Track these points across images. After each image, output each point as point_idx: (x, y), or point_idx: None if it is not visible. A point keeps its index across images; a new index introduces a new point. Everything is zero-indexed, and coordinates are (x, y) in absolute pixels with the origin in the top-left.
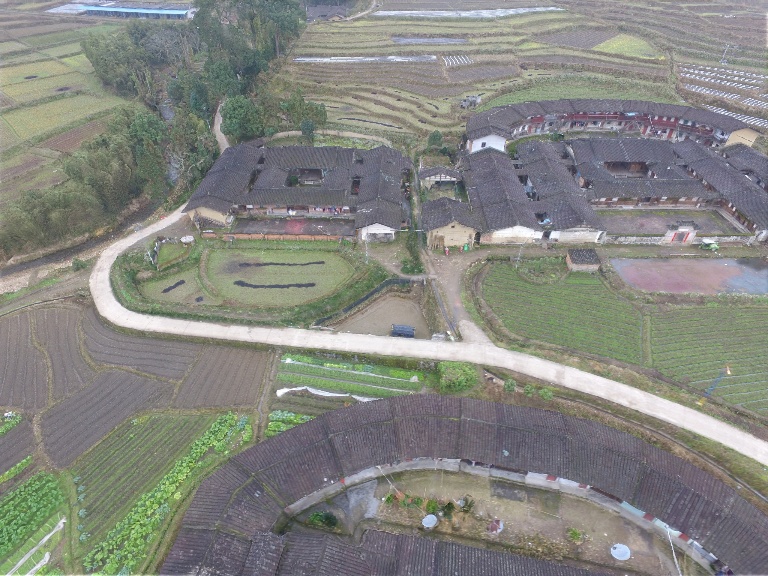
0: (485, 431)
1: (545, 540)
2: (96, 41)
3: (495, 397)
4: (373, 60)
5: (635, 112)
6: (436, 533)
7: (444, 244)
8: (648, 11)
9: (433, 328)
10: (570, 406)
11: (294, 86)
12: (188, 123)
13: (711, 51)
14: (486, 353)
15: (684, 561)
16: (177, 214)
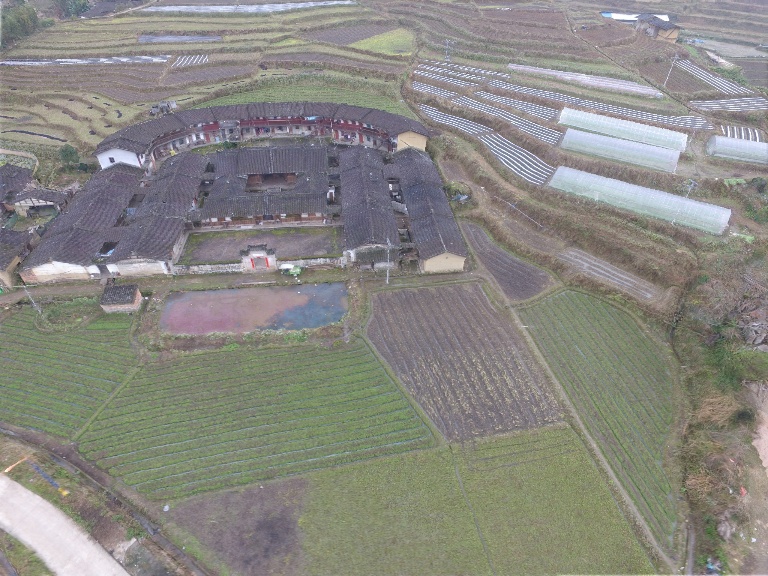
0: None
1: None
2: None
3: None
4: (92, 62)
5: (315, 116)
6: None
7: None
8: (436, 4)
9: None
10: None
11: None
12: None
13: (460, 46)
14: None
15: None
16: None
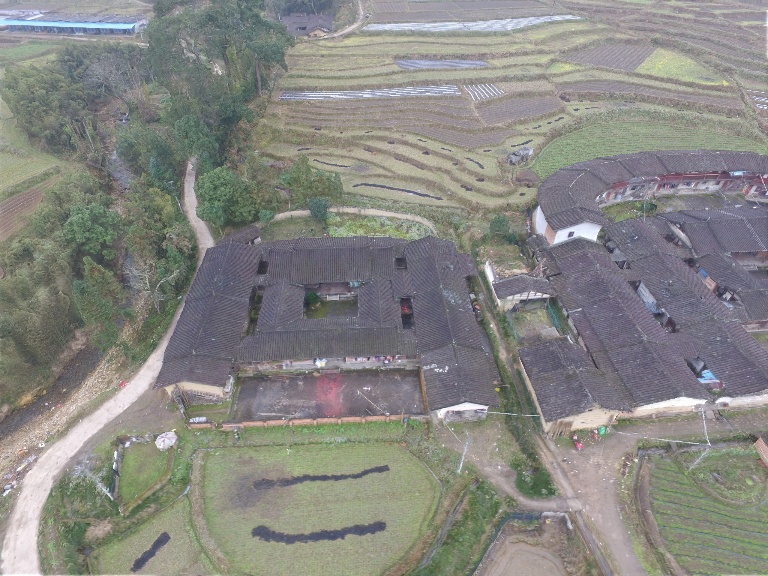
0: None
1: None
2: (14, 80)
3: None
4: (381, 94)
5: (742, 170)
6: None
7: (570, 428)
8: (678, 19)
9: None
10: None
11: (286, 135)
12: (150, 206)
13: None
14: None
15: None
16: (145, 375)
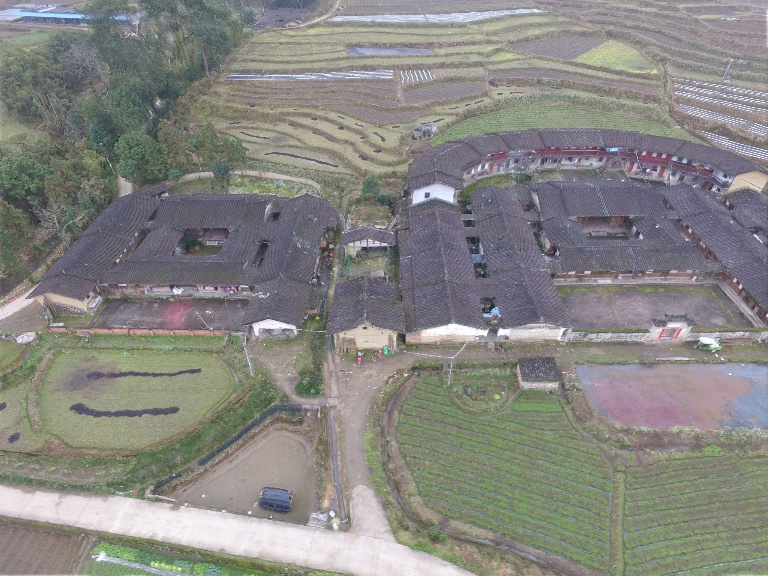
0: None
1: None
2: None
3: None
4: (319, 77)
5: (618, 147)
6: None
7: (357, 347)
8: (640, 13)
9: (319, 493)
10: None
11: (223, 110)
12: (78, 164)
13: (711, 63)
14: (379, 556)
15: None
16: None
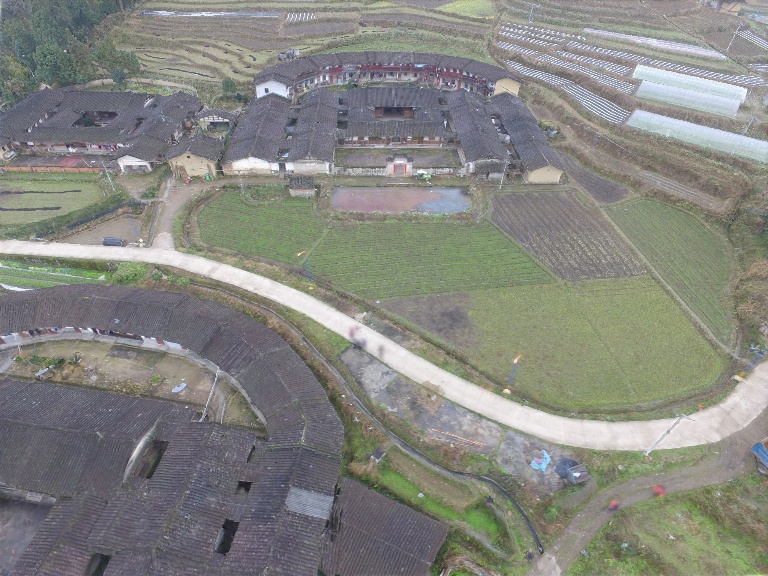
0: (107, 305)
1: (129, 383)
2: None
3: (150, 287)
4: (217, 15)
5: (423, 64)
6: (50, 382)
7: (188, 174)
8: None
9: None
10: (208, 292)
11: (133, 38)
12: (4, 70)
13: (538, 12)
14: (163, 255)
15: (234, 395)
16: None
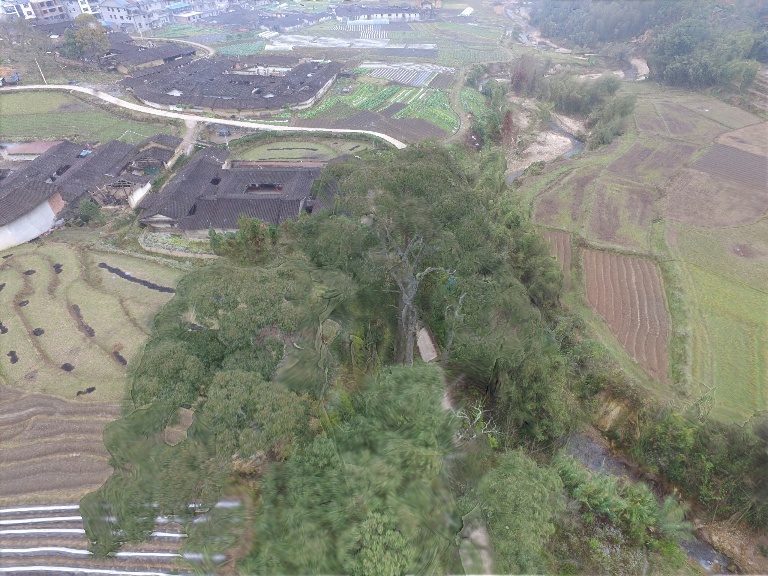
0: None
1: None
2: None
3: None
4: None
5: None
6: None
7: None
8: None
9: None
10: None
11: None
12: None
13: None
14: None
15: None
16: None
